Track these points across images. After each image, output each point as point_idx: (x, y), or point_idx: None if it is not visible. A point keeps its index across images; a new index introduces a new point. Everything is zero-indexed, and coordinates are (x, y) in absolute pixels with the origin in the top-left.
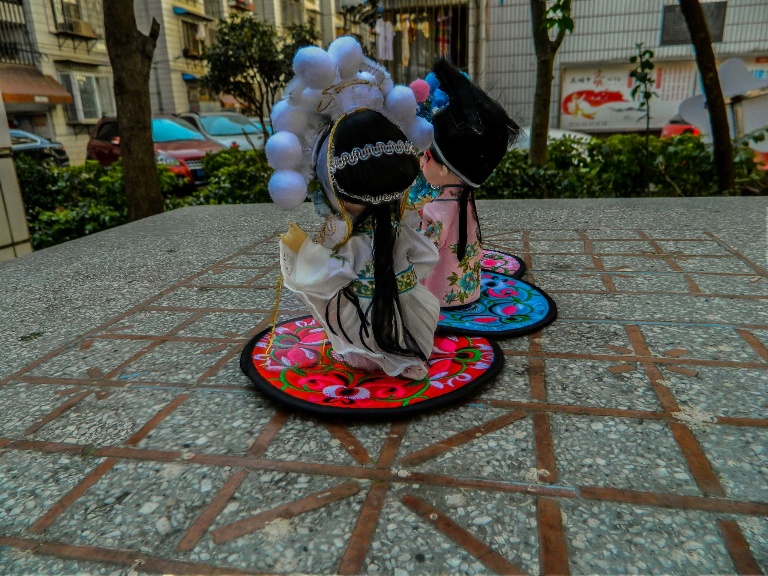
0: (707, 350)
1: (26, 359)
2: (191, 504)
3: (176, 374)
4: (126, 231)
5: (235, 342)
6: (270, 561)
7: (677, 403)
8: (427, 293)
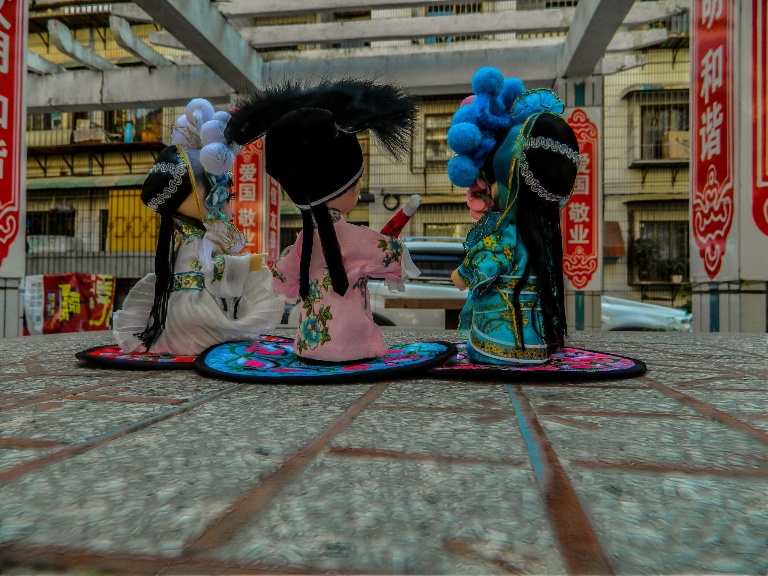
0: (23, 416)
1: None
2: None
3: None
4: None
5: None
6: None
7: None
8: None
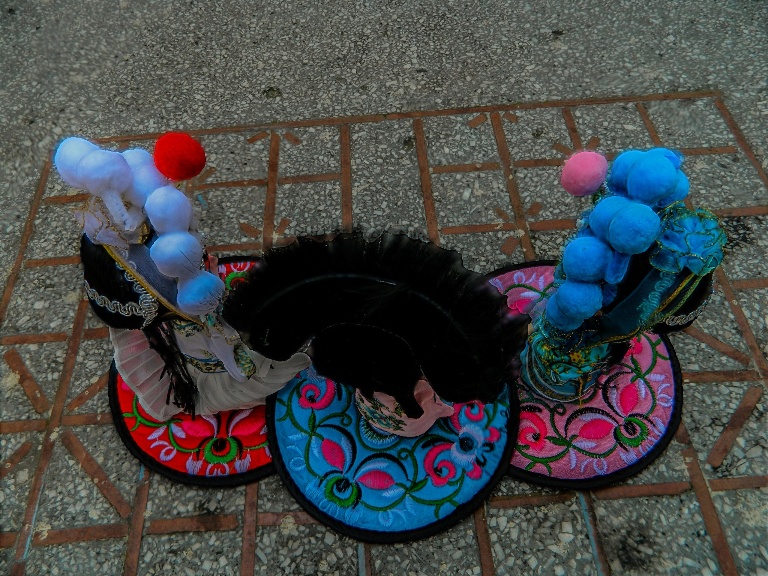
0: None
1: (228, 120)
2: (39, 324)
3: (201, 228)
4: None
5: (264, 238)
6: None
7: None
8: (219, 387)
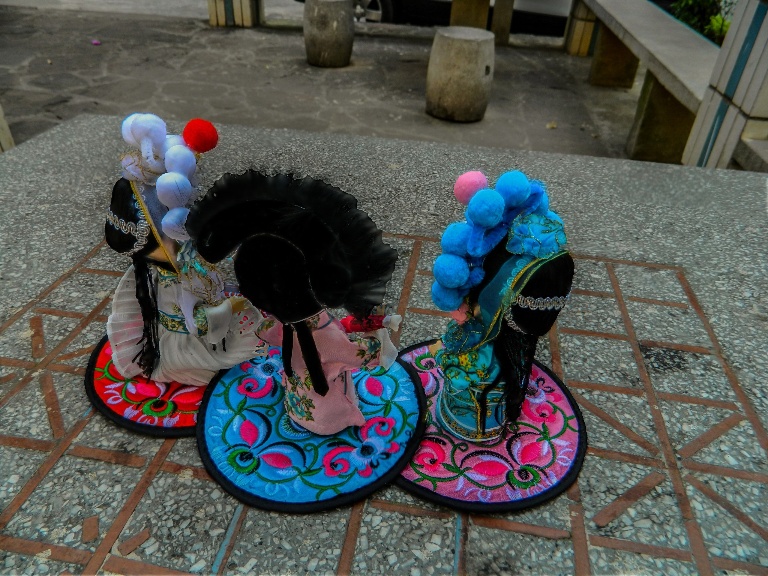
0: None
1: None
2: (67, 305)
3: None
4: (646, 172)
5: None
6: (6, 334)
7: (5, 550)
8: None
